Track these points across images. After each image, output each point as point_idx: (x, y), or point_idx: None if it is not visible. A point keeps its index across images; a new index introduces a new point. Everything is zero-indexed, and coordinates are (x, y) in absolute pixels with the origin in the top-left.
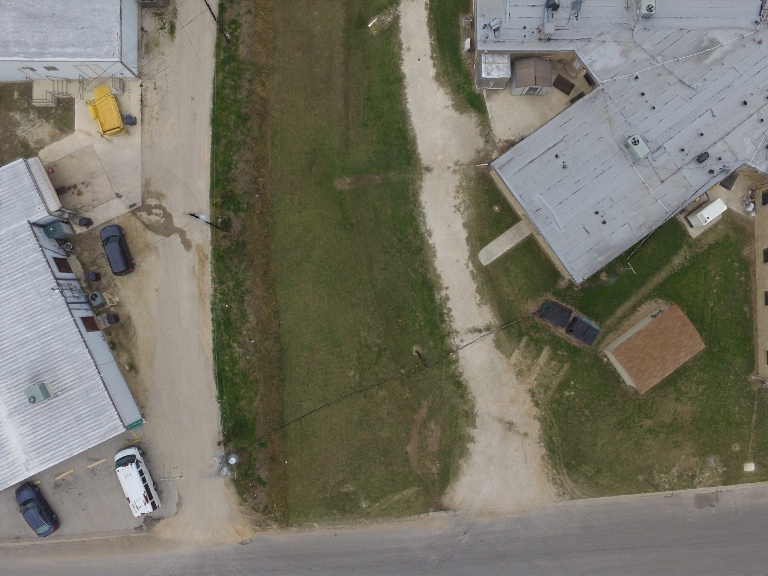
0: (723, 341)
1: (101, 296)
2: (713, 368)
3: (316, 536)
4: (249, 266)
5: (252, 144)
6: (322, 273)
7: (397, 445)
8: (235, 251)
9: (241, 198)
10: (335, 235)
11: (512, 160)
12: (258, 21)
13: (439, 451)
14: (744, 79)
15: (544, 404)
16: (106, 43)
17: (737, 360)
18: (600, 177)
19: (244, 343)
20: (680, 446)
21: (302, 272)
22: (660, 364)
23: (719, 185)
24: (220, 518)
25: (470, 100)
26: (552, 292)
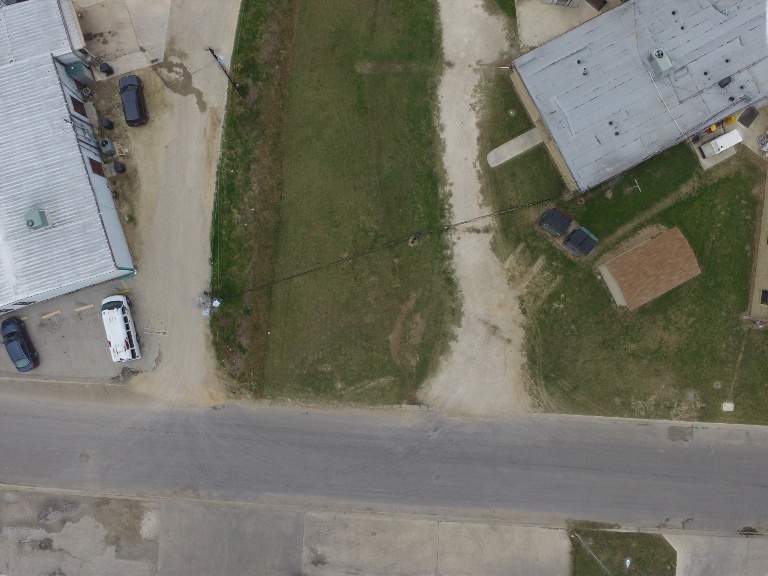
0: (720, 276)
1: (111, 144)
2: (706, 302)
3: (288, 411)
4: (260, 135)
5: (279, 16)
6: (330, 152)
7: (380, 332)
8: (248, 119)
9: (261, 68)
10: (348, 117)
11: (534, 60)
12: None
13: (421, 344)
14: None
15: (532, 313)
16: None
17: (731, 298)
18: (619, 88)
19: (244, 210)
20: (662, 375)
21: (311, 149)
22: (653, 283)
23: (737, 121)
24: (196, 380)
25: (500, 2)
26: (555, 203)
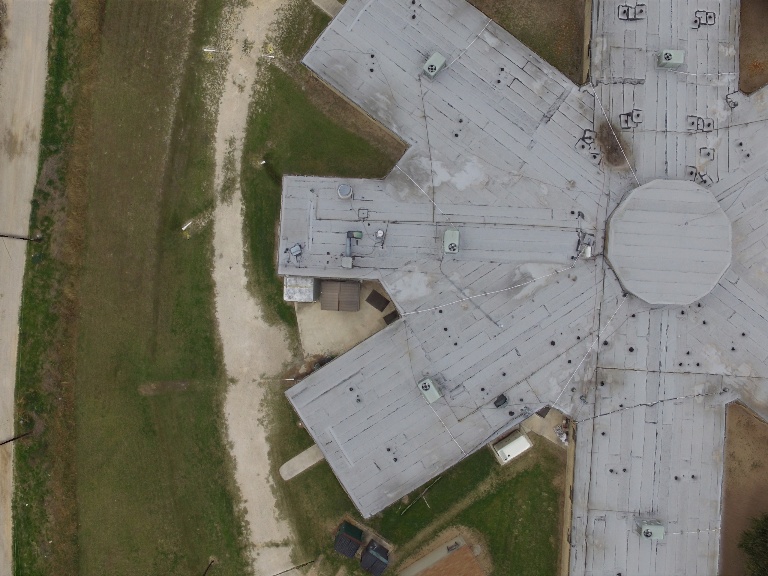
0: (525, 570)
1: None
2: None
3: None
4: (50, 467)
5: (58, 346)
6: (122, 478)
7: None
8: (37, 452)
9: (45, 399)
10: (137, 442)
11: (306, 390)
12: (69, 221)
13: None
14: (553, 319)
15: None
16: None
17: None
18: (393, 415)
19: (42, 543)
20: None
21: (102, 476)
22: None
23: None
24: None
25: (280, 312)
26: (351, 512)
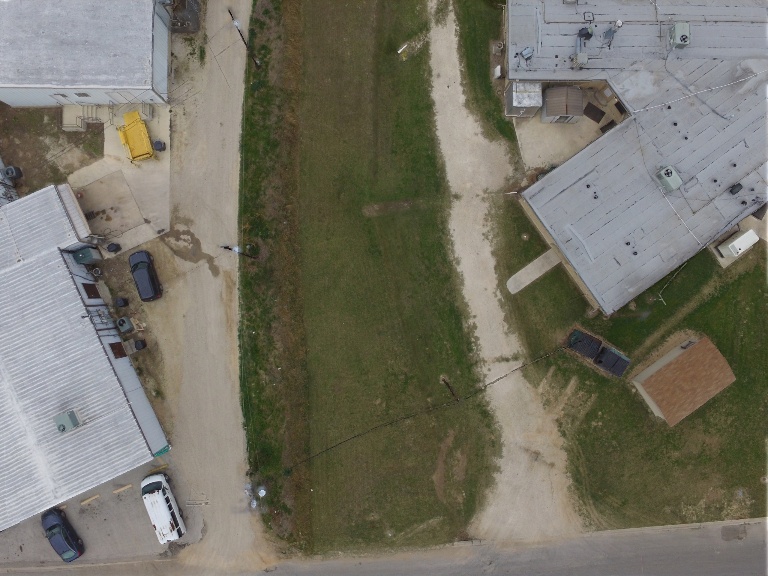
0: (753, 372)
1: (129, 322)
2: (742, 399)
3: (341, 564)
4: (276, 293)
5: (281, 170)
6: (349, 300)
7: (423, 474)
8: (263, 278)
9: (269, 225)
10: (363, 262)
11: (543, 190)
12: (288, 47)
13: (465, 480)
14: None
15: (571, 434)
16: (138, 71)
17: (767, 392)
18: (632, 208)
19: (271, 370)
20: (708, 478)
21: (329, 299)
22: (690, 397)
23: (750, 215)
24: (245, 545)
25: (499, 128)
26: (581, 322)
